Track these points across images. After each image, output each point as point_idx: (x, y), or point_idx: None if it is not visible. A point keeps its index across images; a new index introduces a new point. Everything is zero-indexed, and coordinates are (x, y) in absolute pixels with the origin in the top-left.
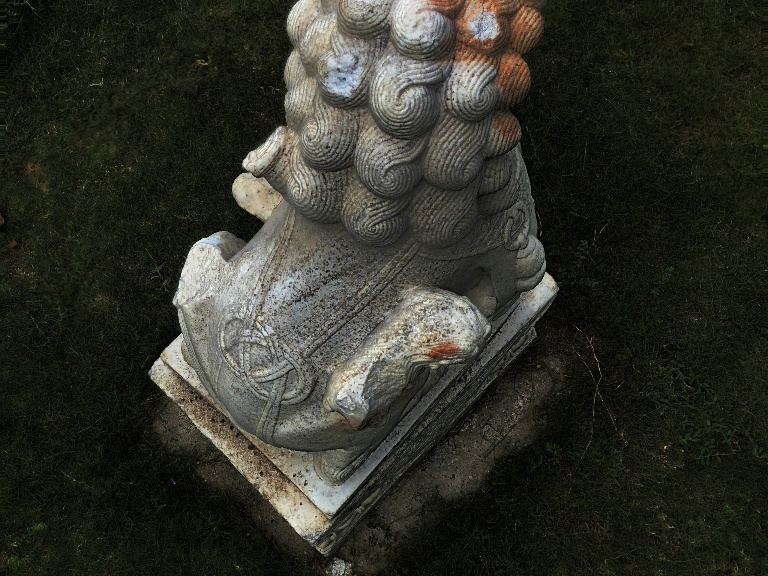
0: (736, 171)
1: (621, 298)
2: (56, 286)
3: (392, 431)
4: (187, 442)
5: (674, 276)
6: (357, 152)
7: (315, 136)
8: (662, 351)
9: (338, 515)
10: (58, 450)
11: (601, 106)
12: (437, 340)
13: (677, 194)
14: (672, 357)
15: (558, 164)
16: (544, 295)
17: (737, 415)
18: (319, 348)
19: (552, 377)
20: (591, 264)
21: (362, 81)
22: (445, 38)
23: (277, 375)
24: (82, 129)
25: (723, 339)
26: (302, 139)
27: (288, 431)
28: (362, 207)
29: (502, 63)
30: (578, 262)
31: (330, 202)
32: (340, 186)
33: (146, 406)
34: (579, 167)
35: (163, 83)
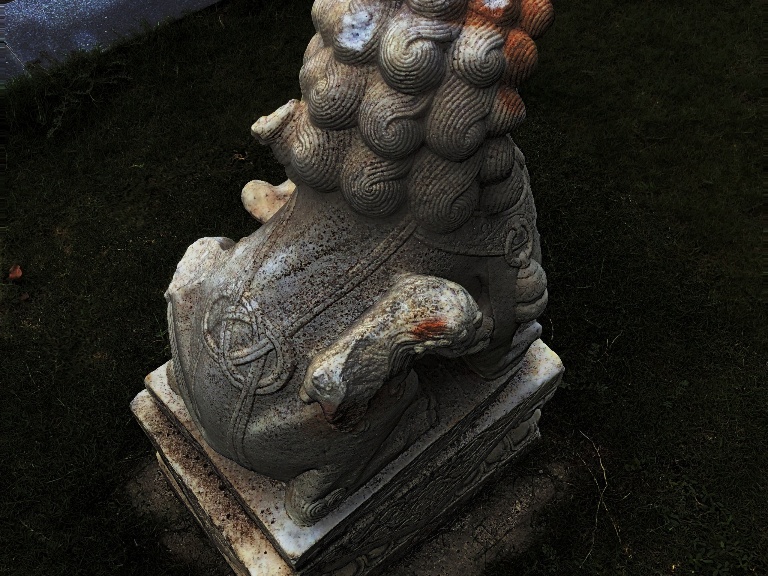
0: (754, 299)
1: (632, 408)
2: (58, 339)
3: (373, 477)
4: (159, 508)
5: (688, 392)
6: (362, 107)
7: (323, 89)
8: (673, 466)
9: (304, 569)
10: (22, 497)
11: (620, 229)
12: (424, 316)
13: (693, 314)
14: (684, 472)
15: (574, 277)
16: (548, 371)
17: (754, 539)
18: (303, 328)
19: (554, 484)
20: (602, 372)
21: (374, 36)
22: (456, 0)
23: (256, 355)
24: (115, 203)
25: (739, 459)
26: (311, 95)
27: (260, 430)
28: (361, 166)
29: (510, 35)
30: (588, 367)
31: (331, 162)
32: (342, 146)
33: (123, 465)
34: (595, 281)
35: (200, 172)
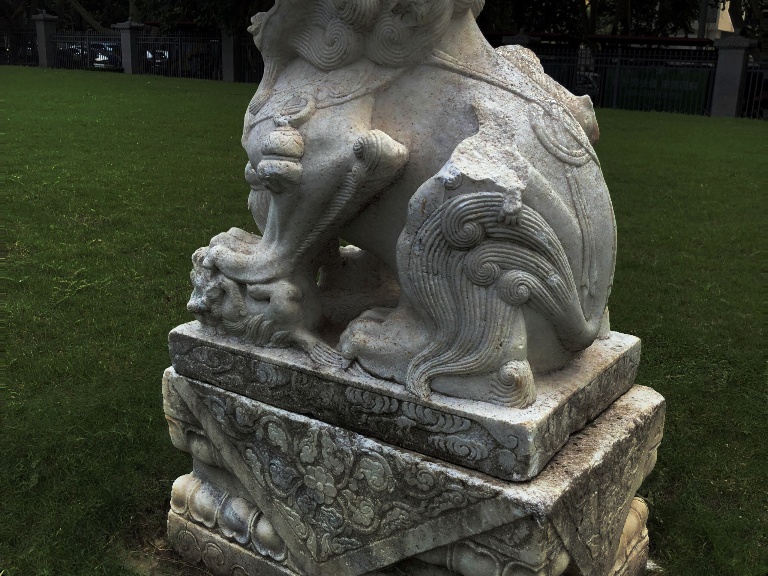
0: None
1: None
2: None
3: None
4: None
5: None
6: None
7: None
8: None
9: None
10: None
11: None
12: None
13: None
14: None
15: None
16: None
17: None
18: None
19: None
20: None
21: None
22: None
23: None
24: None
25: None
26: None
27: None
28: None
29: None
30: None
31: None
32: None
33: None
34: None
35: None
